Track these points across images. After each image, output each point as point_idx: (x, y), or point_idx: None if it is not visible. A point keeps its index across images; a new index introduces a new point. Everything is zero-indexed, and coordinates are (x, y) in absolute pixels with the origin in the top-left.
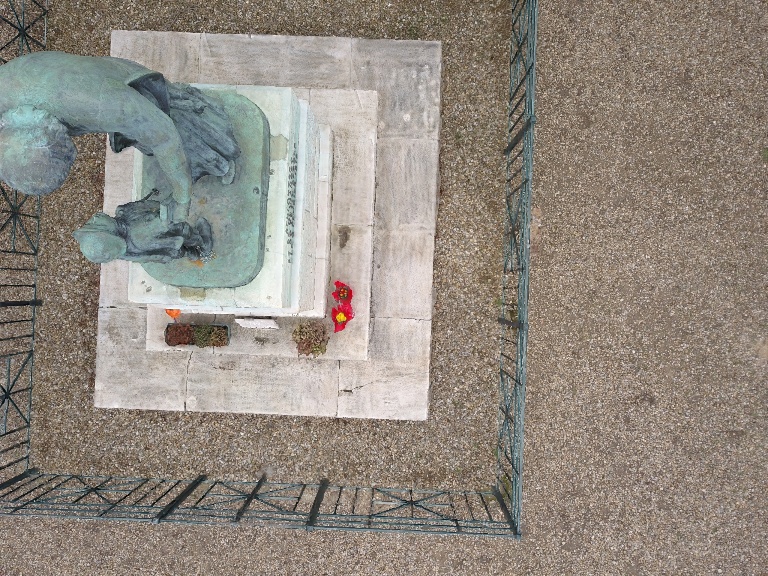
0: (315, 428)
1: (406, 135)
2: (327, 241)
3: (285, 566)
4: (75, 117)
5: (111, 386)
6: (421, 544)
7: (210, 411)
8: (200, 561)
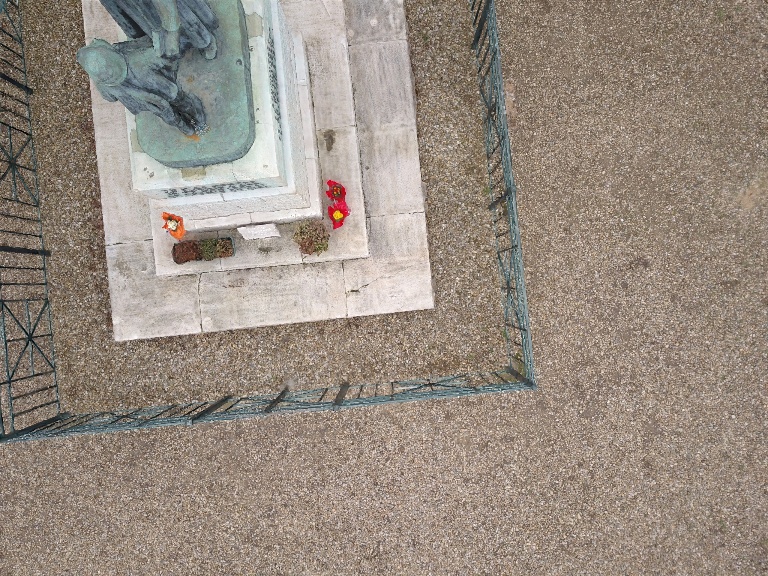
0: (329, 336)
1: (375, 39)
2: (314, 144)
3: (319, 472)
4: None
5: (128, 319)
6: (446, 432)
7: (226, 329)
8: (237, 479)
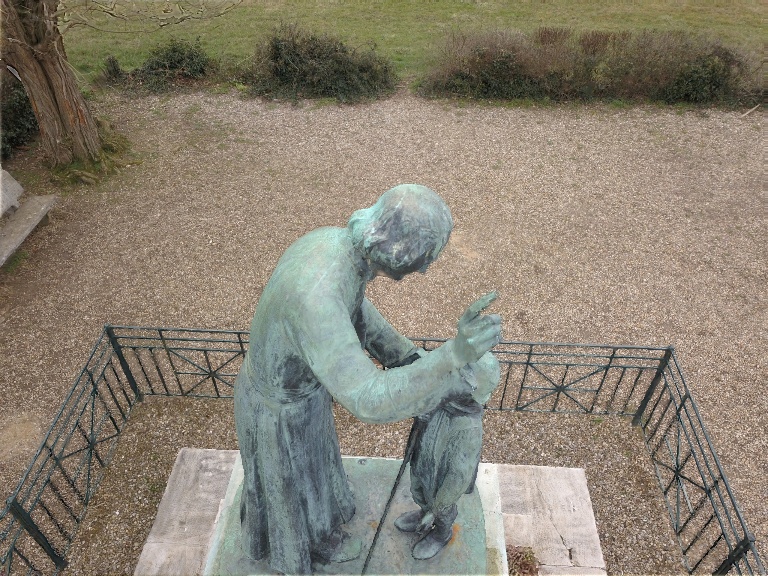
0: None
1: None
2: None
3: None
4: None
5: None
6: None
7: None
8: None
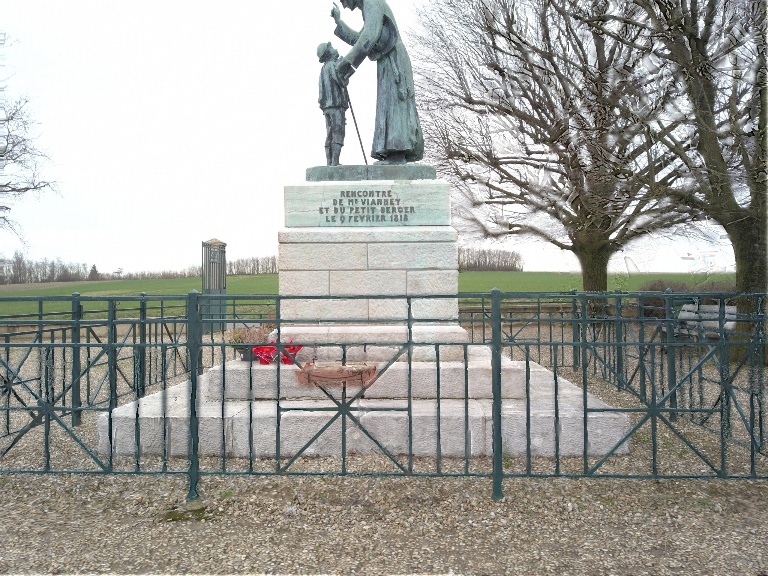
0: None
1: None
2: None
3: None
4: None
5: None
6: None
7: None
8: None
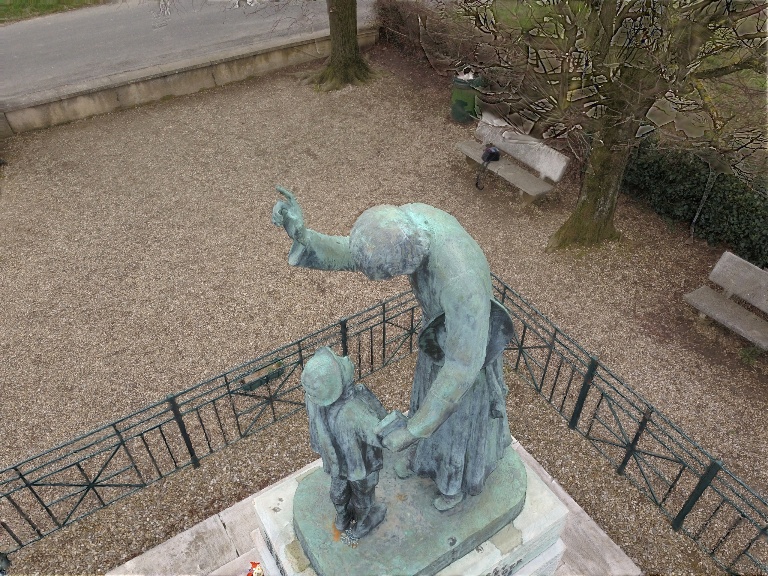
0: None
1: None
2: None
3: None
4: (438, 263)
5: None
6: None
7: None
8: None
